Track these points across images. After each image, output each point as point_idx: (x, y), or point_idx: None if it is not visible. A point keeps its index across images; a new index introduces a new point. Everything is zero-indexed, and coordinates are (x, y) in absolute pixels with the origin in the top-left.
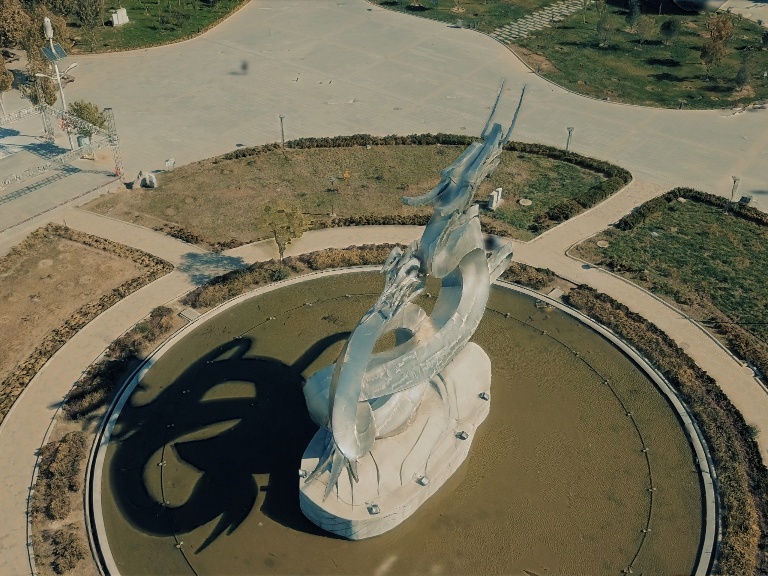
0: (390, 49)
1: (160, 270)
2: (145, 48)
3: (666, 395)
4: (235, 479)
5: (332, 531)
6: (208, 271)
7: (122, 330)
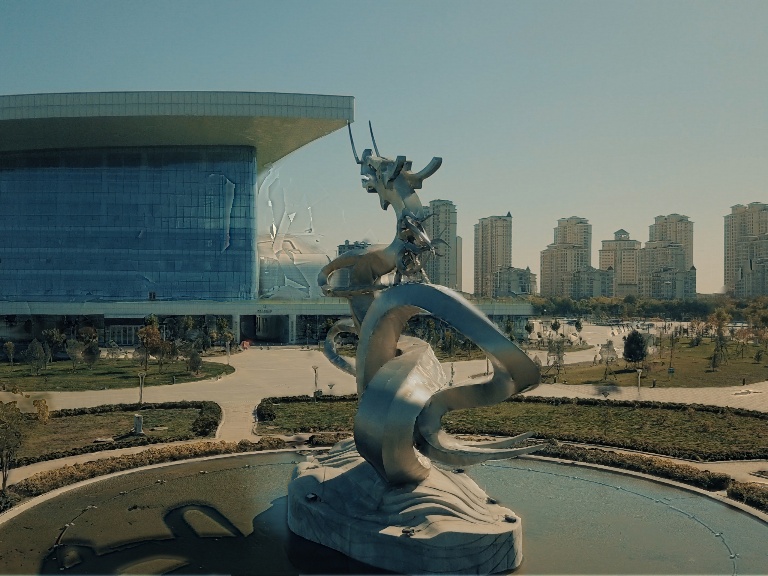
0: None
1: None
2: None
3: None
4: None
5: (493, 571)
6: None
7: None
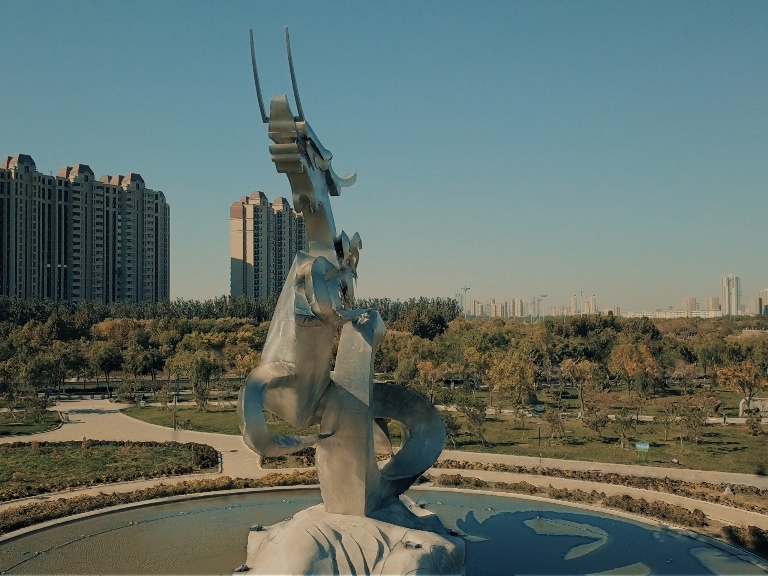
0: None
1: None
2: None
3: None
4: None
5: None
6: None
7: None
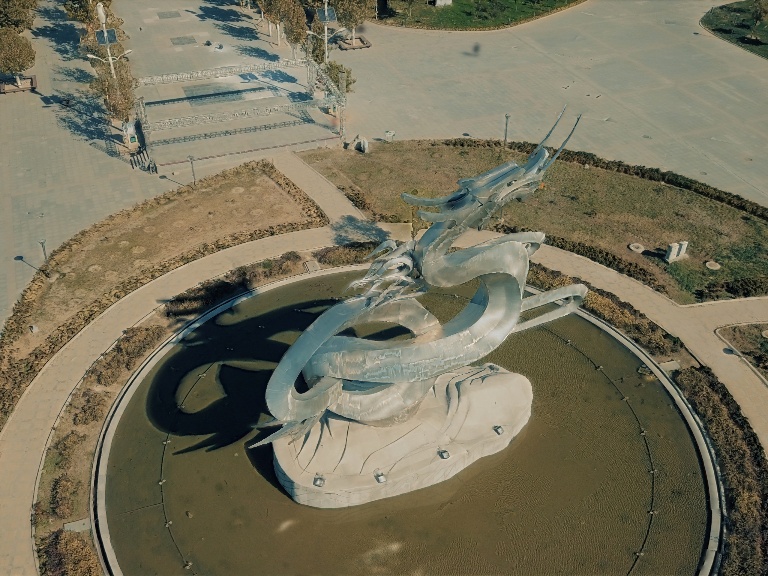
0: (687, 77)
1: (316, 222)
2: (450, 30)
3: (710, 511)
4: (253, 413)
5: (284, 486)
6: (354, 235)
7: (252, 261)
